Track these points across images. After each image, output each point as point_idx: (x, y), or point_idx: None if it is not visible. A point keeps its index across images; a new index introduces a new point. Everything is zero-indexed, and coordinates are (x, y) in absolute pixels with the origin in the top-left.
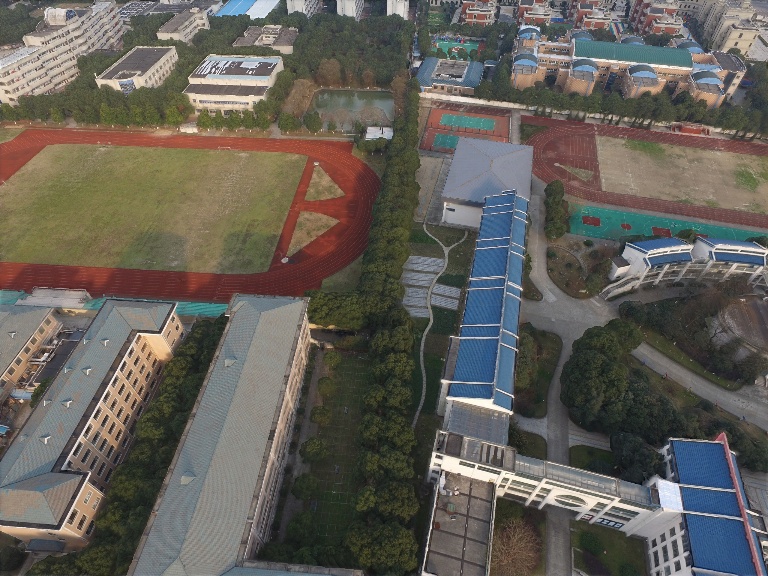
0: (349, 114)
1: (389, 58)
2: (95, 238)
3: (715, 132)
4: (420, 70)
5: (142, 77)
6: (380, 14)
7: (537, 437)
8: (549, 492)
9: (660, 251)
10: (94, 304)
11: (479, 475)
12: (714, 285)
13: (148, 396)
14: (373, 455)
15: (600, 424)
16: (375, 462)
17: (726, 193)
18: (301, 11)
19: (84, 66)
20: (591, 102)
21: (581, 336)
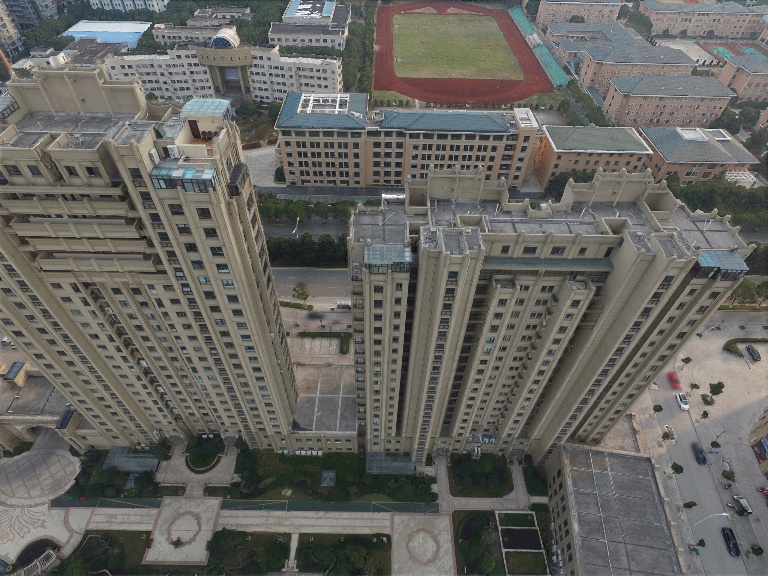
0: None
1: None
2: None
3: None
4: None
5: None
6: None
7: None
8: None
9: None
10: None
11: None
12: None
13: None
14: None
15: None
16: None
17: None
18: (167, 2)
19: None
20: None
21: None
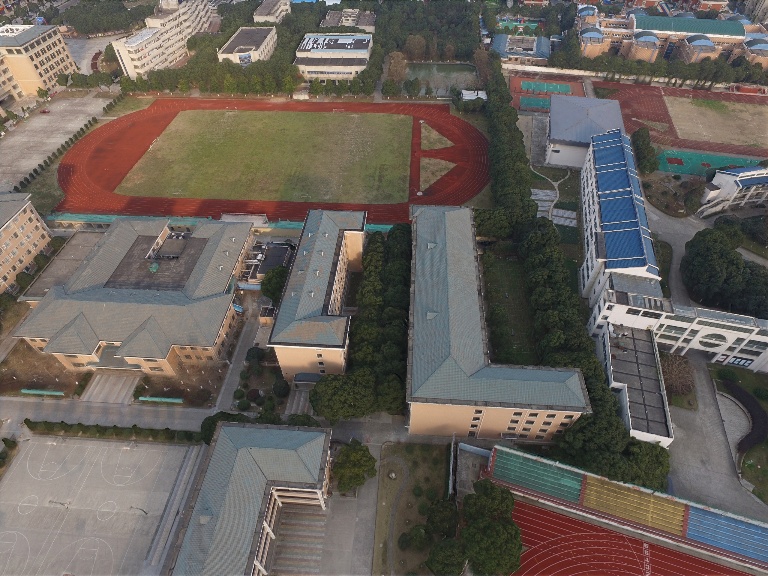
0: (444, 80)
1: (462, 35)
2: (252, 180)
3: None
4: (493, 45)
5: (257, 51)
6: None
7: None
8: (696, 334)
9: (749, 174)
10: (276, 225)
11: (640, 323)
12: None
13: (345, 287)
14: (554, 311)
15: (721, 297)
16: (556, 315)
17: None
18: None
19: (193, 46)
20: (657, 67)
21: None
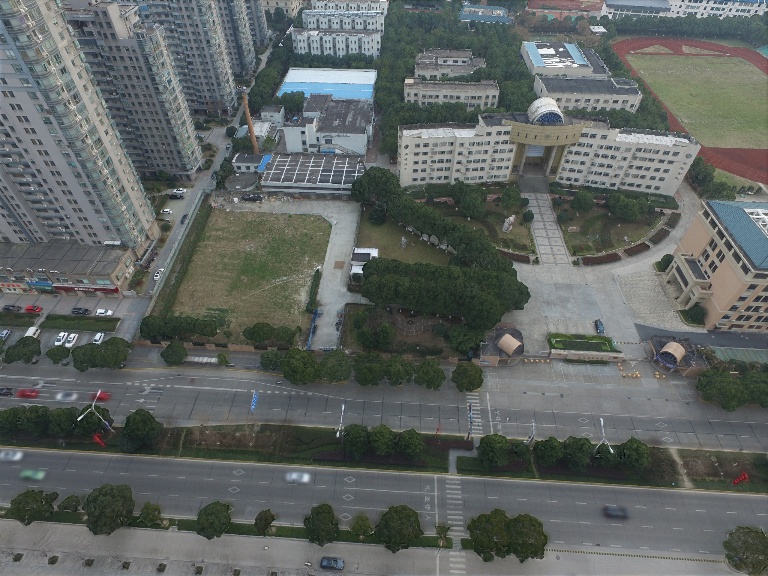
0: None
1: None
2: None
3: None
4: (486, 20)
5: None
6: None
7: None
8: None
9: None
10: None
11: None
12: None
13: None
14: None
15: None
16: None
17: None
18: None
19: None
20: None
21: None
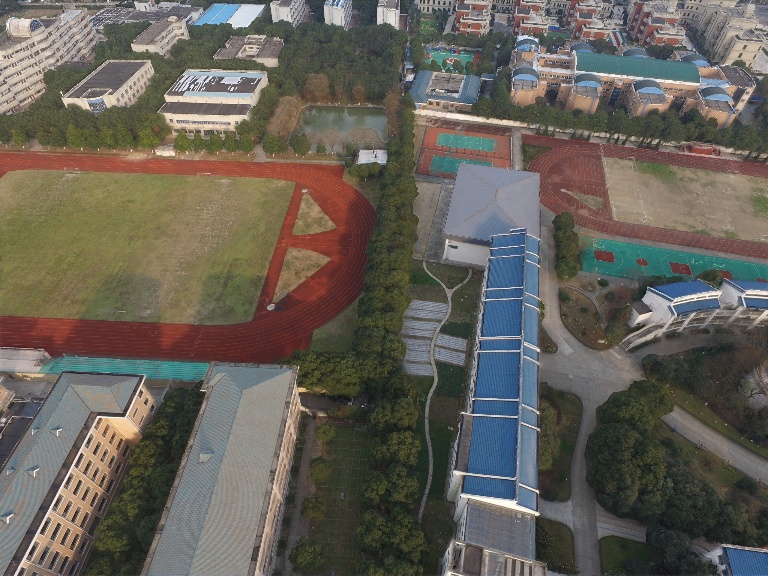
0: (339, 135)
1: (381, 71)
2: (57, 283)
3: (726, 152)
4: (414, 84)
5: (113, 95)
6: (370, 22)
7: (562, 527)
8: None
9: (686, 298)
10: (53, 367)
11: None
12: (742, 331)
13: (112, 484)
14: (376, 570)
15: (634, 513)
16: None
17: (744, 222)
18: (286, 20)
19: (51, 81)
20: (596, 121)
21: (603, 397)
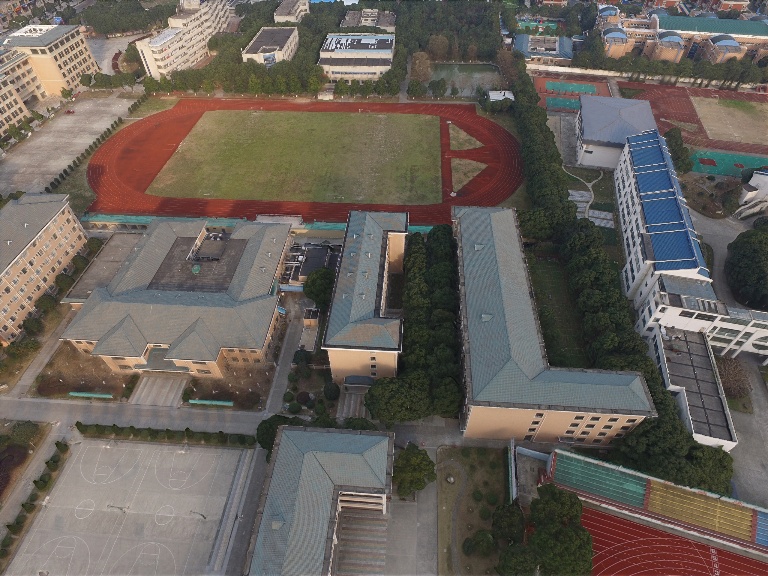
0: (470, 80)
1: (483, 36)
2: (283, 180)
3: None
4: (515, 45)
5: (282, 51)
6: None
7: None
8: (750, 336)
9: None
10: (312, 226)
11: (692, 325)
12: None
13: None
14: (605, 313)
15: None
16: (608, 318)
17: None
18: None
19: (215, 46)
20: (683, 67)
21: None
